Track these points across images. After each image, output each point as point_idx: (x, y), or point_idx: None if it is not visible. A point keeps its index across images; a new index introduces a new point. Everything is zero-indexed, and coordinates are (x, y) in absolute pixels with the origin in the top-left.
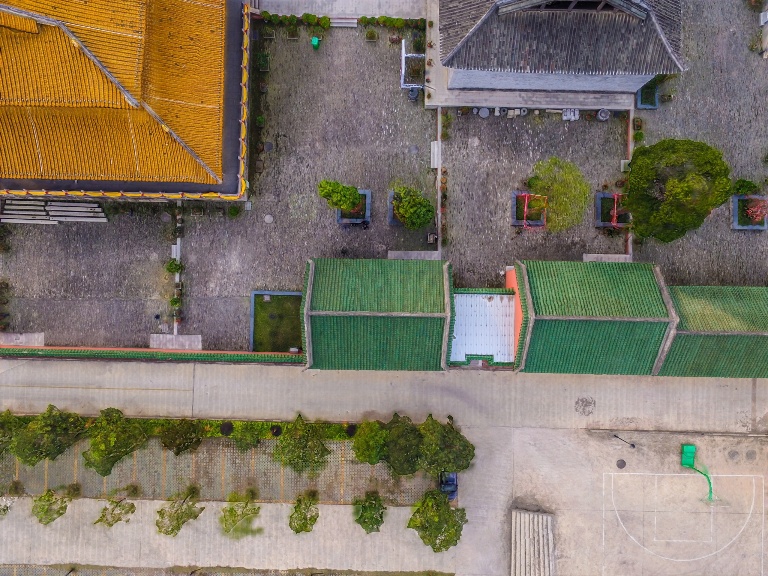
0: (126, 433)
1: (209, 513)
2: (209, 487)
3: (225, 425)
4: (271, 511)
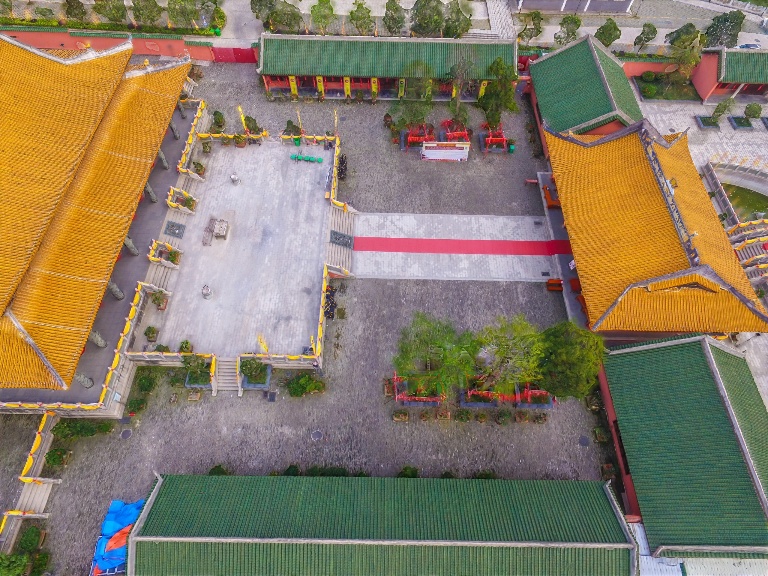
0: (97, 4)
1: (93, 1)
2: (88, 8)
3: (62, 22)
4: (58, 0)
